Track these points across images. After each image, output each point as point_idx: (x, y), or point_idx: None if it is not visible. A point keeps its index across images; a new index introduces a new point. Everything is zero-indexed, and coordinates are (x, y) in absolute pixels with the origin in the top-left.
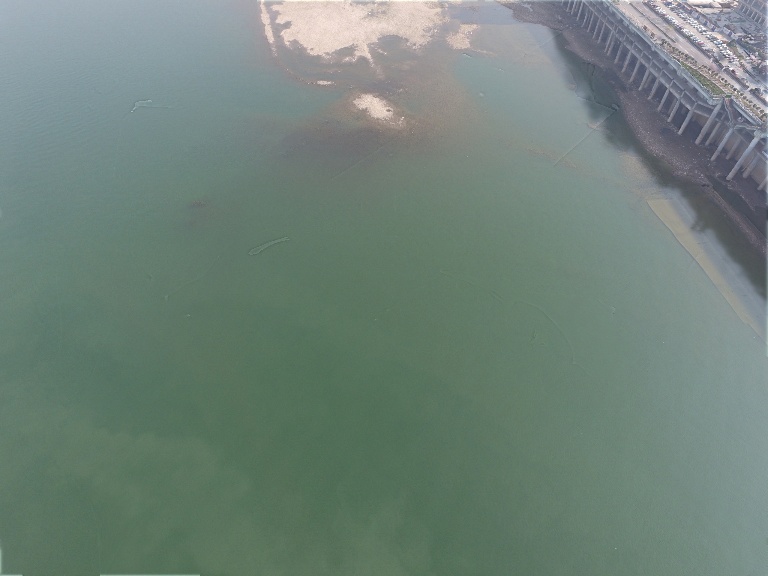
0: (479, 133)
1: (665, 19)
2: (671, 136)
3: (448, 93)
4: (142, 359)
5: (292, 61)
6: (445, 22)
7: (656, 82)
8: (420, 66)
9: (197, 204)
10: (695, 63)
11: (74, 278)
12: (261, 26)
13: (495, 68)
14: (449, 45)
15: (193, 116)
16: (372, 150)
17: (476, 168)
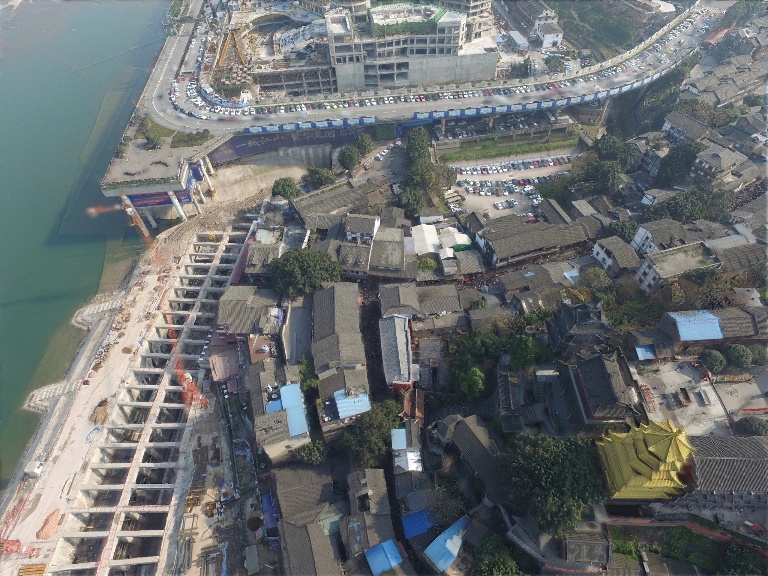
0: (39, 54)
1: None
2: None
3: (48, 29)
4: None
5: None
6: None
7: None
8: (49, 11)
9: None
10: None
11: None
12: None
13: (109, 12)
14: None
15: None
16: None
17: (10, 76)
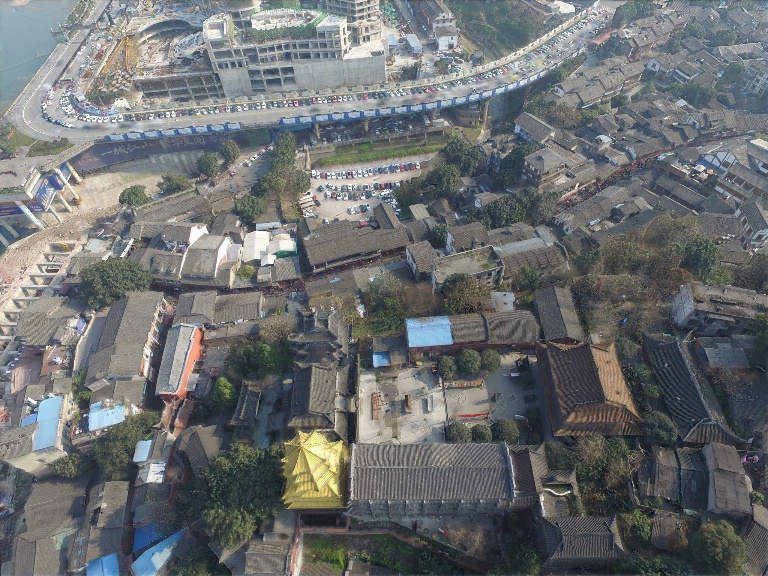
0: None
1: None
2: None
3: None
4: None
5: None
6: None
7: None
8: None
9: None
10: (93, 2)
11: None
12: None
13: (26, 19)
14: (10, 3)
15: None
16: None
17: None
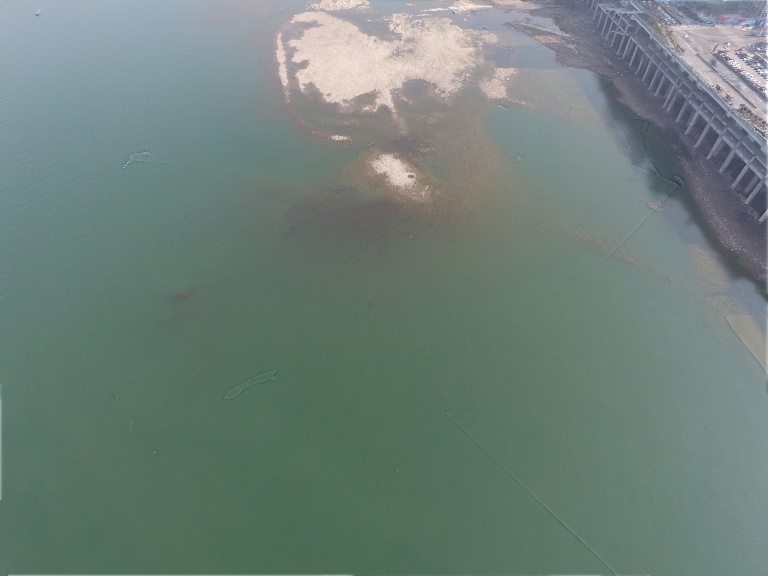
0: (516, 210)
1: (741, 76)
2: (751, 224)
3: (480, 155)
4: (86, 526)
5: (306, 109)
6: (478, 64)
7: (731, 154)
8: (449, 119)
9: (181, 295)
10: None
11: (20, 402)
12: (275, 65)
13: (535, 124)
14: (482, 93)
15: (190, 175)
16: (389, 229)
17: (512, 259)
